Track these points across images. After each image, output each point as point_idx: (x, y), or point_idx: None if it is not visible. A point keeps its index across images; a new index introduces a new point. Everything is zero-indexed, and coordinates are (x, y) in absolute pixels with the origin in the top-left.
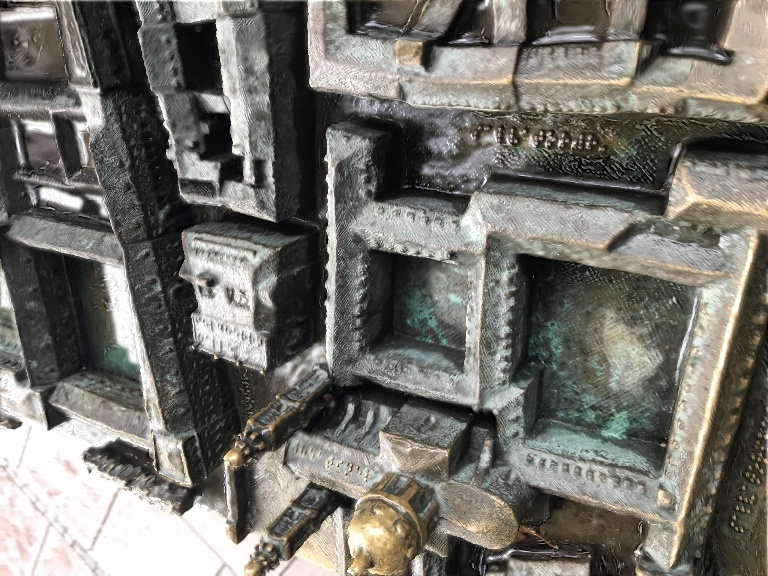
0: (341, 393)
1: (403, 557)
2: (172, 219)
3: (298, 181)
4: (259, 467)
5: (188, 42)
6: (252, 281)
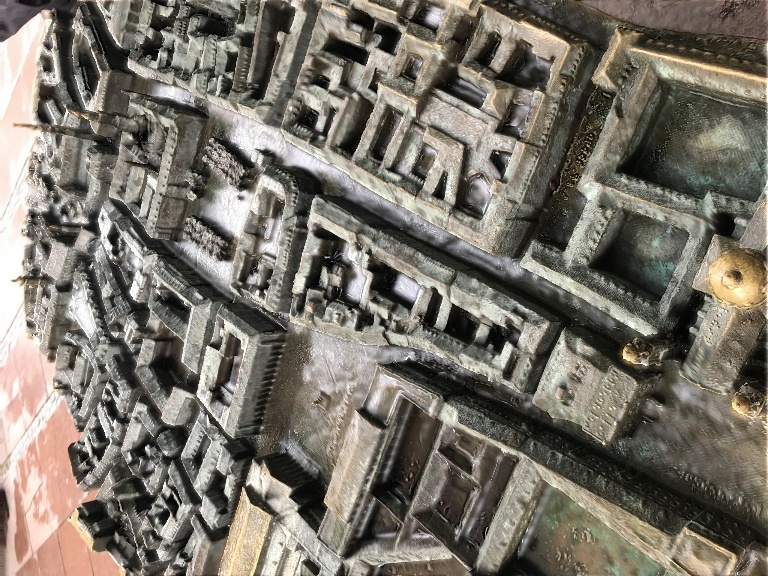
0: (682, 337)
1: (747, 255)
2: (531, 426)
3: (544, 310)
4: None
5: (454, 335)
6: (572, 353)
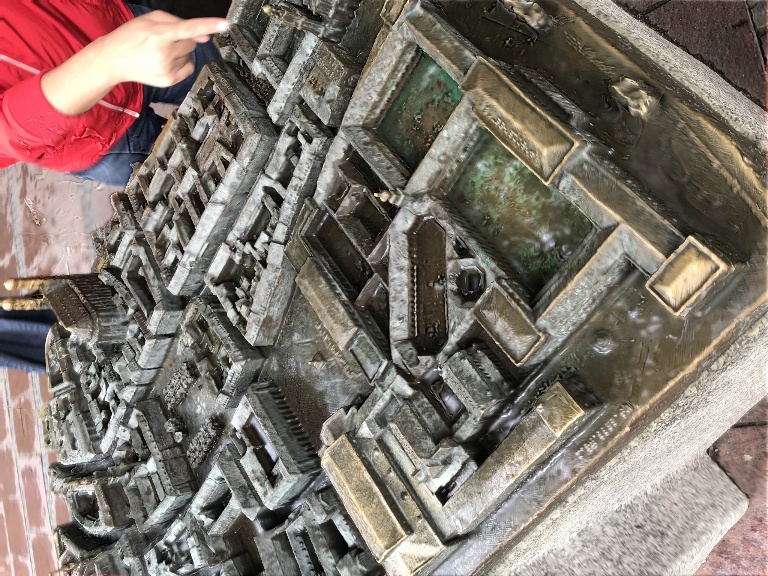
0: None
1: None
2: None
3: None
4: None
5: None
6: None
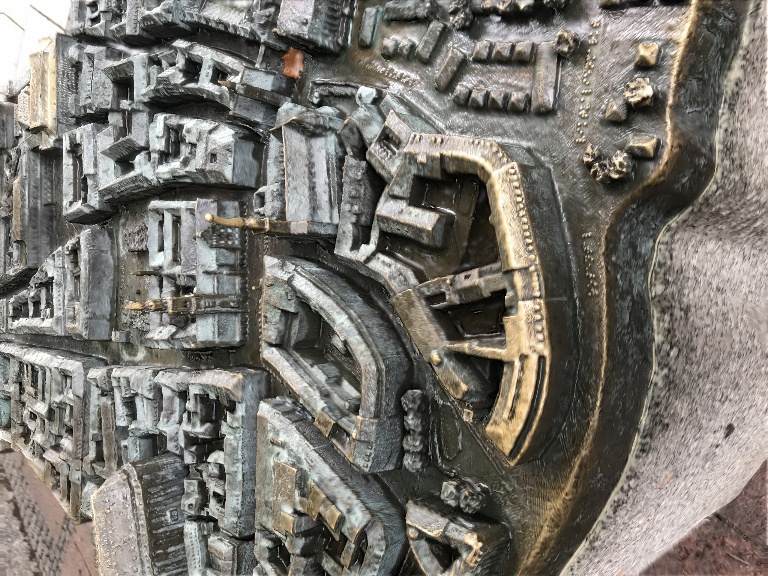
0: None
1: None
2: None
3: None
4: None
5: None
6: None
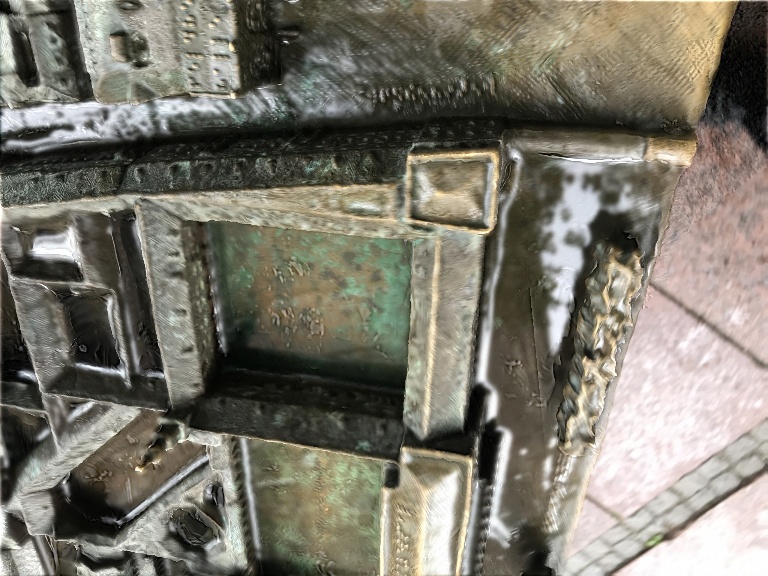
0: None
1: None
2: None
3: None
4: (537, 91)
5: None
6: None
